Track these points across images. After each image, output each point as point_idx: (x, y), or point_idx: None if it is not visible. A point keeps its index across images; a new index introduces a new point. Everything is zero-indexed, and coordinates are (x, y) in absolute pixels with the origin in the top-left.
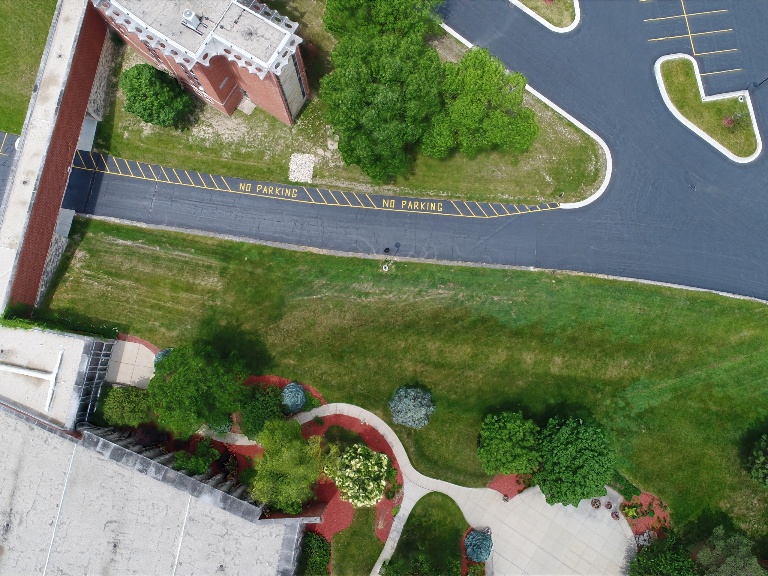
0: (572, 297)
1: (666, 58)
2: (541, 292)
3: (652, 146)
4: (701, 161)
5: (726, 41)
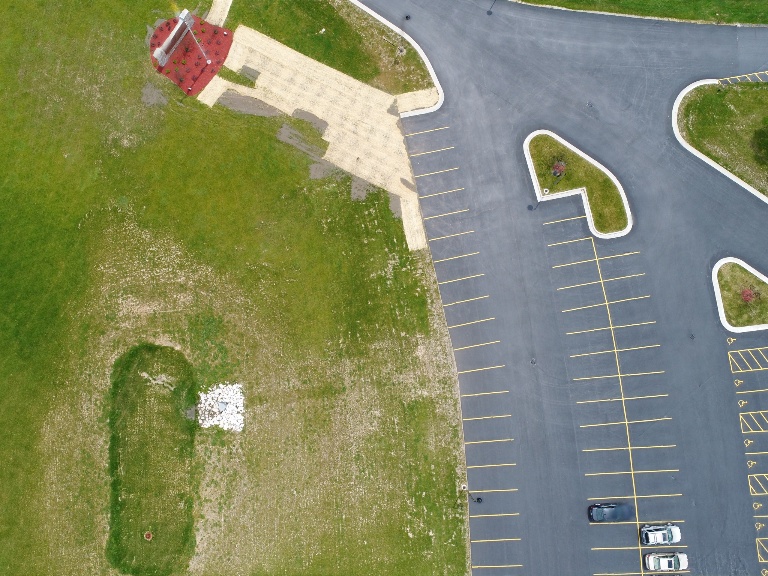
0: (701, 0)
1: (621, 233)
2: (729, 4)
3: (633, 142)
4: (583, 130)
5: (559, 254)
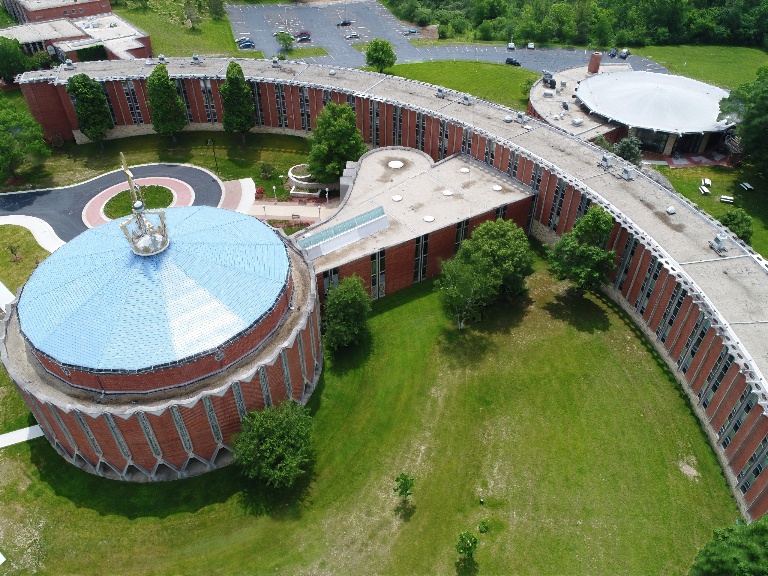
0: None
1: None
2: None
3: None
4: None
5: None
